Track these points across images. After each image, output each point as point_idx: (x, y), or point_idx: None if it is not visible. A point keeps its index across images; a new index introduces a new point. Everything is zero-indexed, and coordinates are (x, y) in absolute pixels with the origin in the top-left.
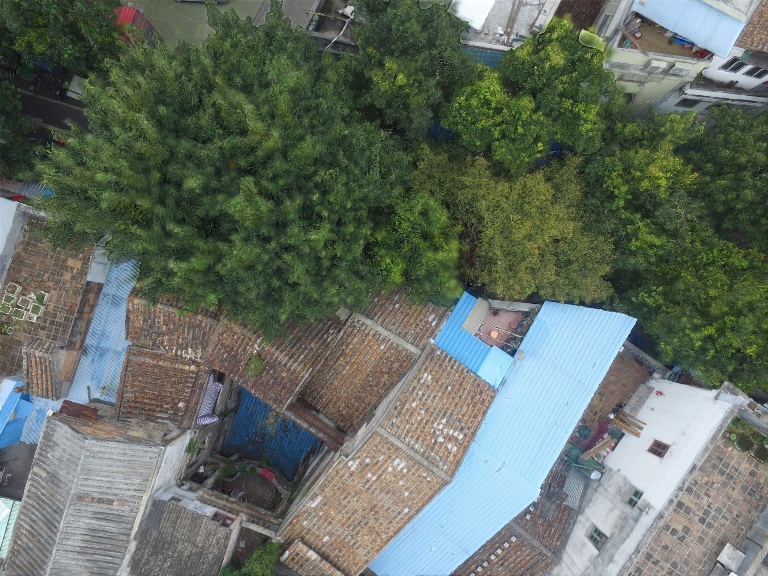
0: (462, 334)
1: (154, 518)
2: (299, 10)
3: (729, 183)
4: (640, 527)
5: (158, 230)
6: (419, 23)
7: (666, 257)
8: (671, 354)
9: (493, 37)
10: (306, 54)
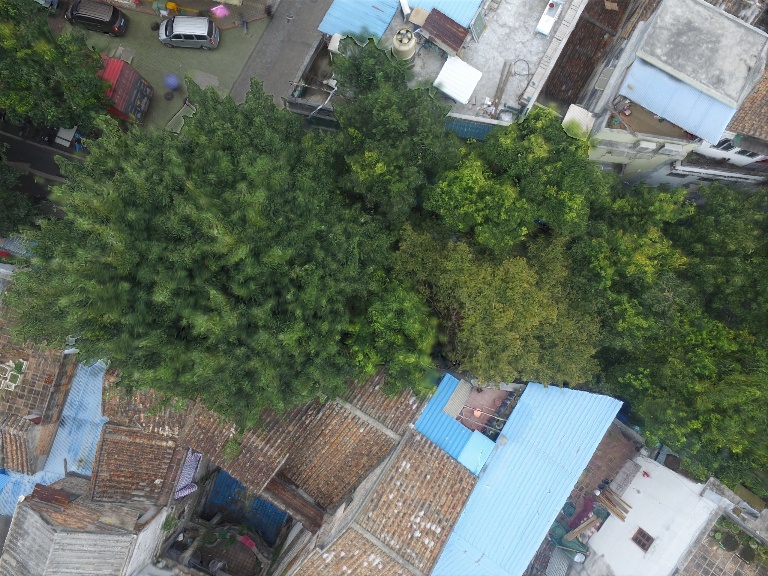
0: (443, 418)
1: None
2: (291, 56)
3: (719, 265)
4: None
5: (125, 338)
6: (401, 109)
7: (654, 336)
8: (657, 440)
9: (480, 108)
10: (288, 129)
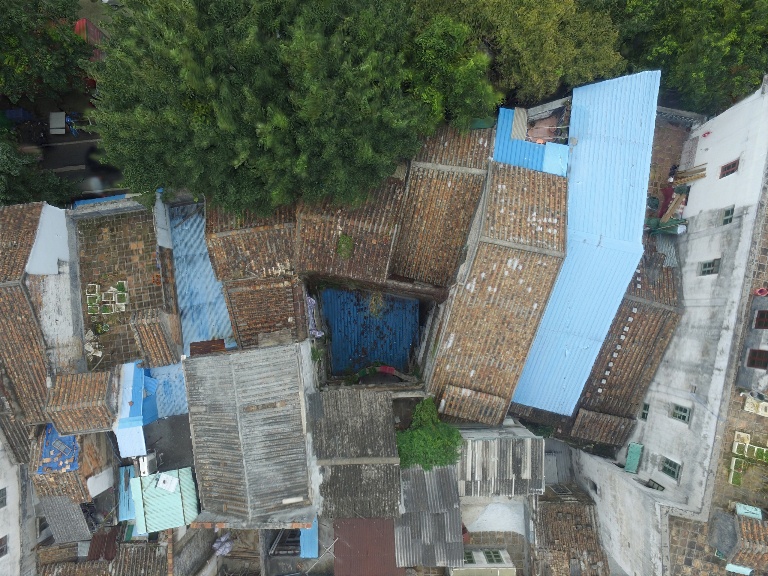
0: (514, 144)
1: (316, 409)
2: None
3: None
4: (746, 227)
5: (226, 111)
6: None
7: (661, 11)
8: (704, 85)
9: None
10: None
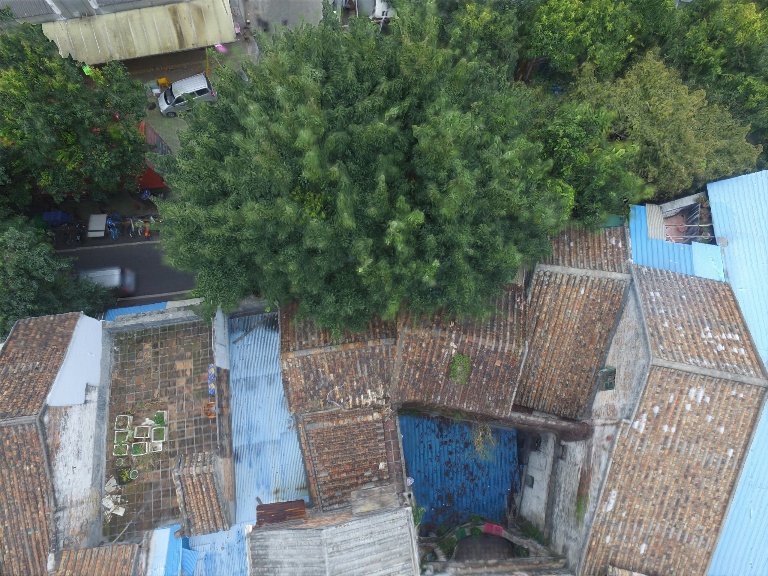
0: (654, 244)
1: None
2: None
3: None
4: None
5: (347, 201)
6: None
7: None
8: None
9: None
10: None
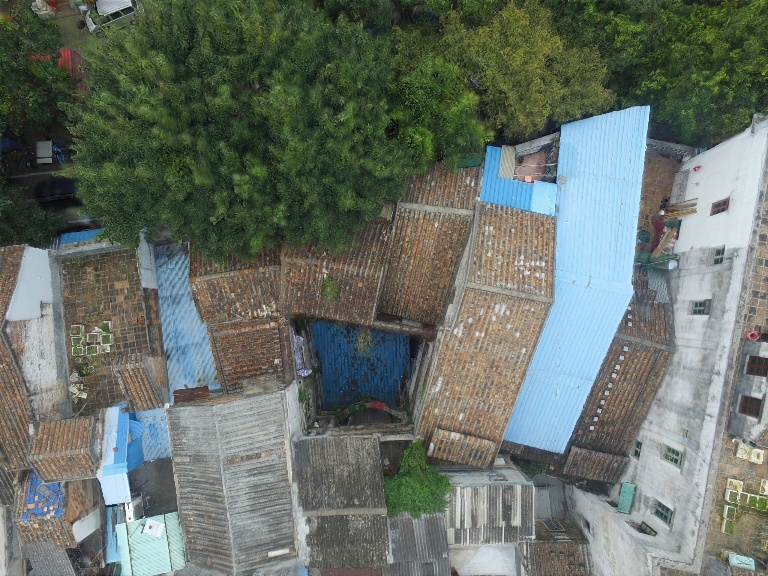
0: (502, 183)
1: (302, 458)
2: None
3: None
4: (737, 270)
5: (203, 167)
6: None
7: (650, 44)
8: (693, 121)
9: None
10: None
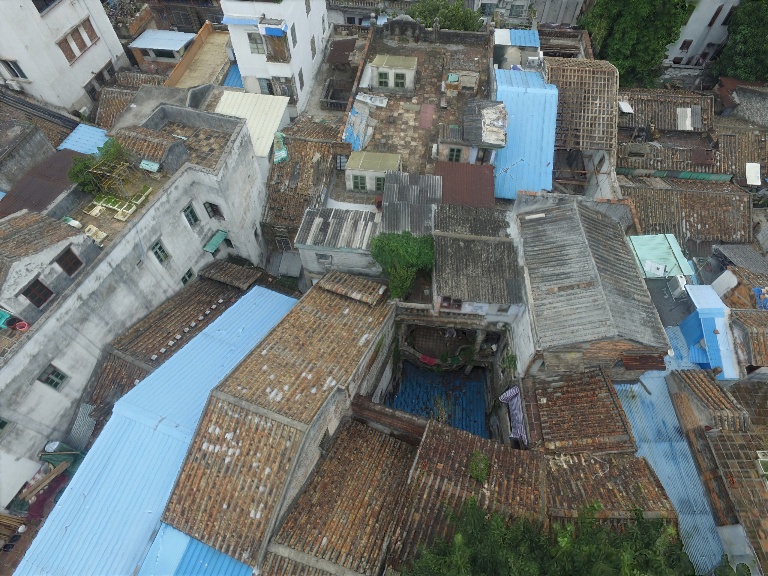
0: None
1: (514, 288)
2: None
3: None
4: None
5: None
6: None
7: None
8: None
9: None
10: None
